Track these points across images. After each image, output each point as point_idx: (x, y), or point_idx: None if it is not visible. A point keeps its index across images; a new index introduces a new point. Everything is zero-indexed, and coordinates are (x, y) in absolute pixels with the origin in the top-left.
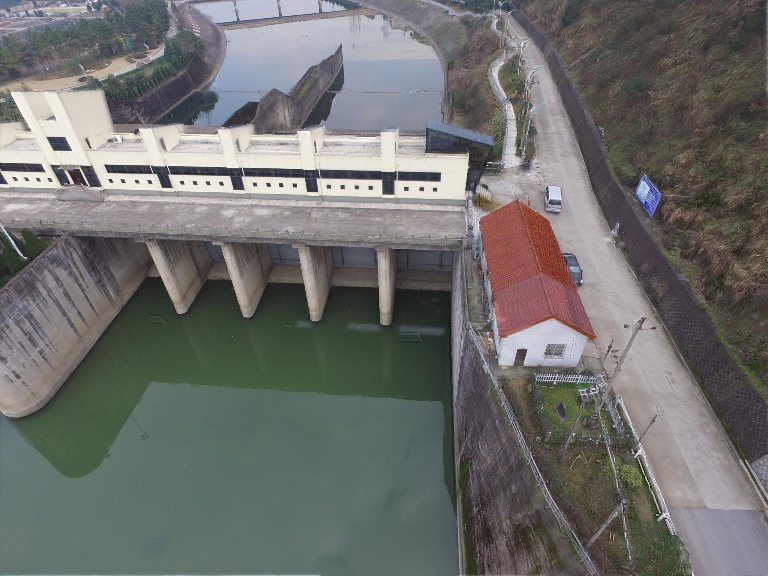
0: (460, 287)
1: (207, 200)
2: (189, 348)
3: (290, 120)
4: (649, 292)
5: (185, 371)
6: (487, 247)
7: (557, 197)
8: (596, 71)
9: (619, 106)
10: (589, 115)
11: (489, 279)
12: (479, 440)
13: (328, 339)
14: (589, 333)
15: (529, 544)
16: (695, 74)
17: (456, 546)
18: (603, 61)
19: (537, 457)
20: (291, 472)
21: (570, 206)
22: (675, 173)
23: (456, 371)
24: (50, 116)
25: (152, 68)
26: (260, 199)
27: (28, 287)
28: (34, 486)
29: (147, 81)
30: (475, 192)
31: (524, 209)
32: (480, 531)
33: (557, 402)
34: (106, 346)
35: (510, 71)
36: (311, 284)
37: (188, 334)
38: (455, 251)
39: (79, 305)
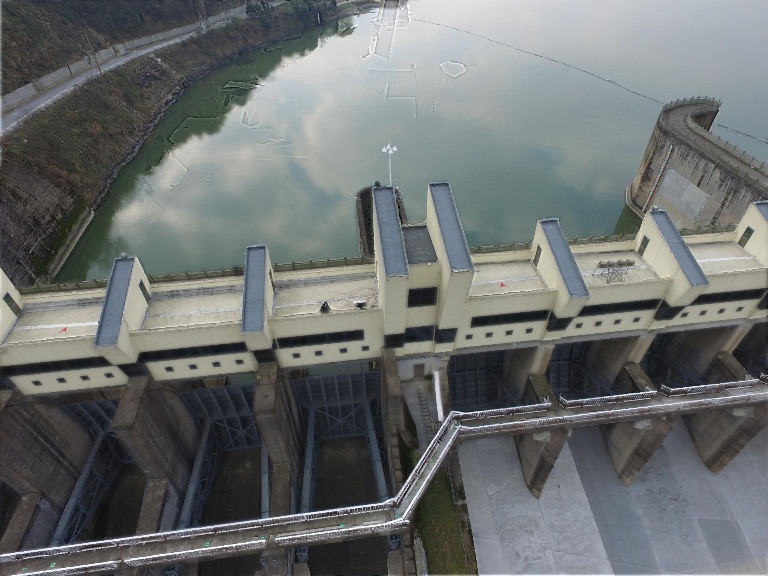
0: None
1: None
2: None
3: None
4: None
5: None
6: None
7: None
8: None
9: None
10: None
11: None
12: None
13: None
14: None
15: None
16: None
17: None
18: None
19: None
20: None
21: None
22: None
23: None
24: None
25: None
26: None
27: None
28: (328, 247)
29: None
30: None
31: None
32: None
33: None
34: None
35: None
36: None
37: None
38: None
39: None
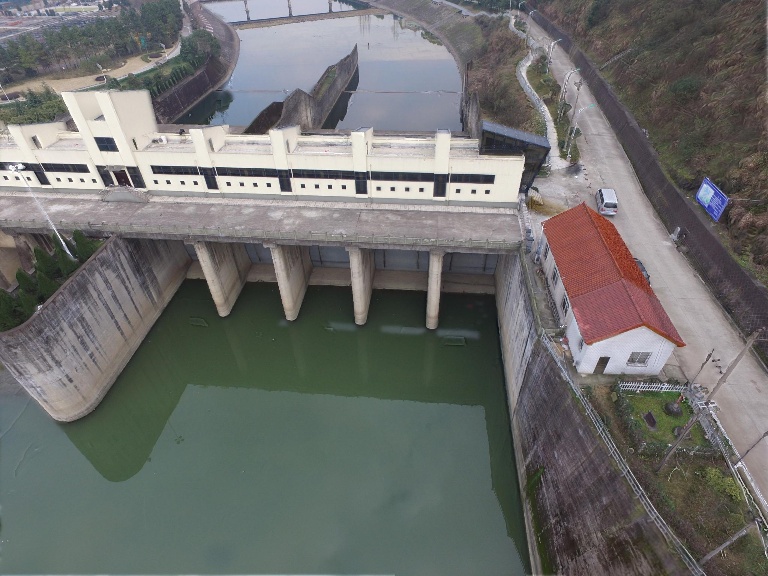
0: (521, 291)
1: (253, 202)
2: (228, 351)
3: (311, 120)
4: (719, 298)
5: (222, 374)
6: (556, 251)
7: (613, 200)
8: (635, 72)
9: (664, 108)
10: (631, 116)
11: (563, 284)
12: (555, 449)
13: (371, 342)
14: (679, 341)
15: (628, 558)
16: (751, 75)
17: (527, 556)
18: (641, 62)
19: (635, 469)
20: (350, 479)
21: (624, 209)
22: (742, 176)
23: (515, 377)
24: (97, 116)
25: (168, 67)
26: (307, 201)
27: (81, 290)
28: (90, 492)
29: (166, 81)
30: (527, 195)
31: (591, 213)
32: (561, 542)
33: (643, 411)
34: (149, 349)
35: (539, 72)
36: (359, 287)
37: (228, 337)
38: (504, 254)
39: (125, 307)
